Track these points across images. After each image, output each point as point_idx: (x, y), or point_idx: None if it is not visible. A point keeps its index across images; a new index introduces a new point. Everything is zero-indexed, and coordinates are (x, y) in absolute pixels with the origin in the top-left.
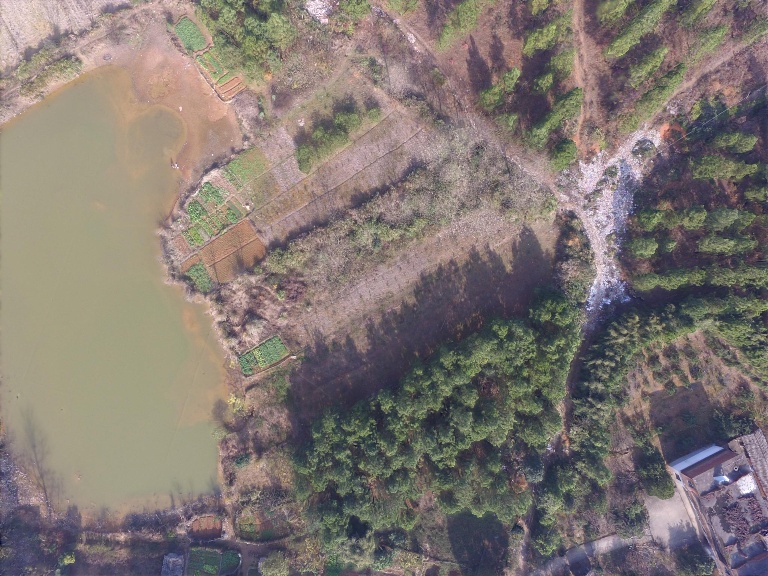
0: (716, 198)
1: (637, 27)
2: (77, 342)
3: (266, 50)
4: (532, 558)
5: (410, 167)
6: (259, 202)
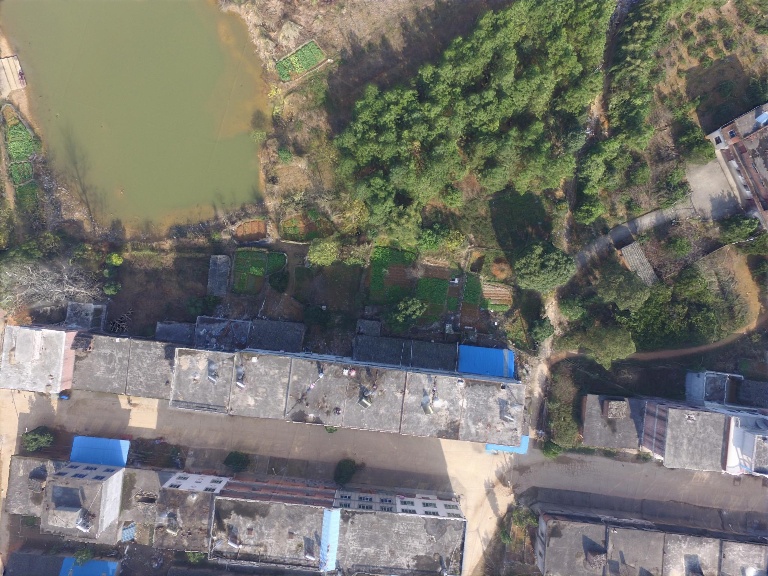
0: None
1: None
2: (114, 60)
3: None
4: (576, 239)
5: None
6: None
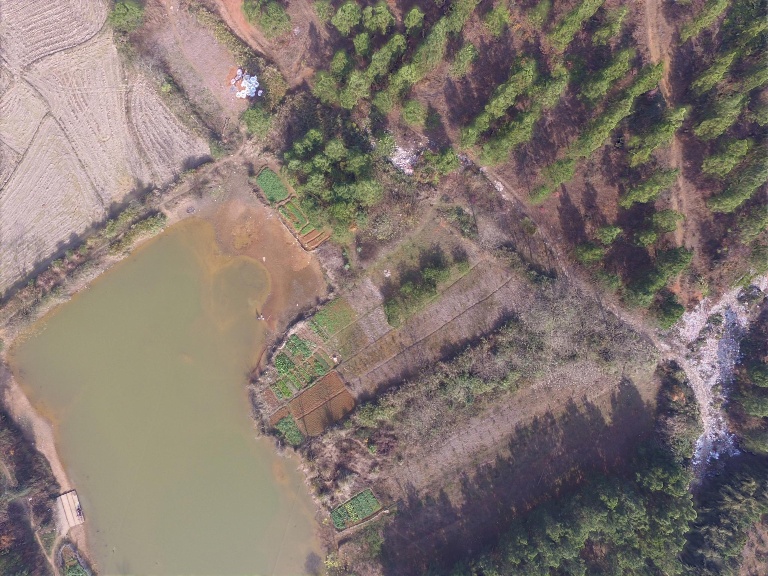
0: None
1: (750, 188)
2: (169, 495)
3: (354, 211)
4: None
5: (501, 317)
6: (346, 354)
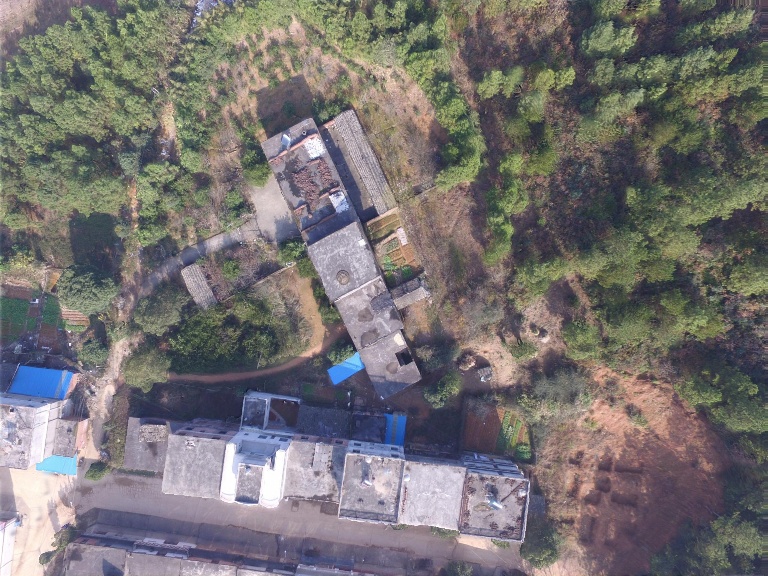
0: None
1: None
2: None
3: None
4: (147, 260)
5: None
6: None
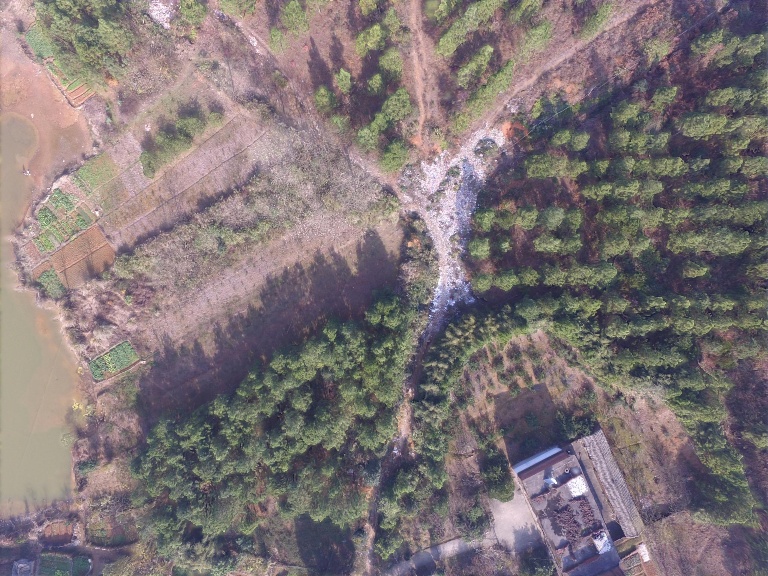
0: (559, 197)
1: (456, 26)
2: None
3: (101, 56)
4: (378, 562)
5: (255, 170)
6: (108, 208)
